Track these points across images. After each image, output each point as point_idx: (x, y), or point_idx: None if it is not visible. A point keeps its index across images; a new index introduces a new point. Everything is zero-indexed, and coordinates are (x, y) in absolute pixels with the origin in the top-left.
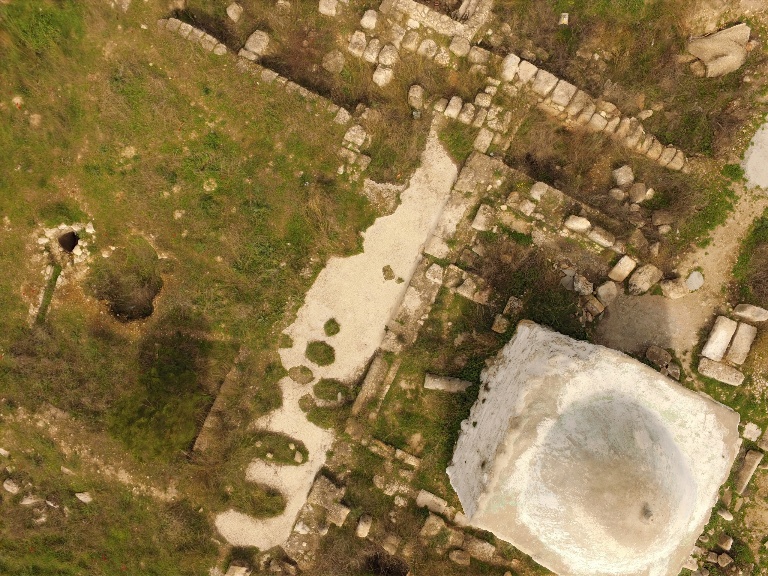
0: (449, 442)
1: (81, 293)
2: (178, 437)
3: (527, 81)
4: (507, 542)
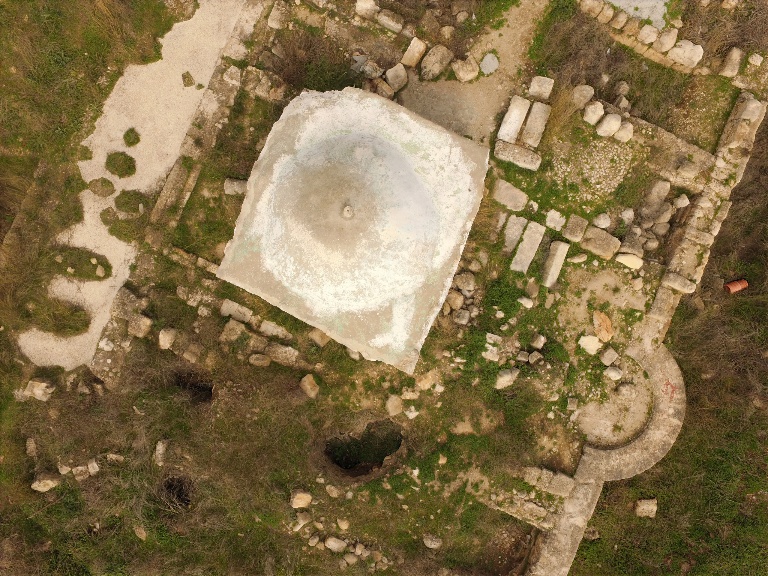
0: None
1: None
2: None
3: None
4: (310, 346)
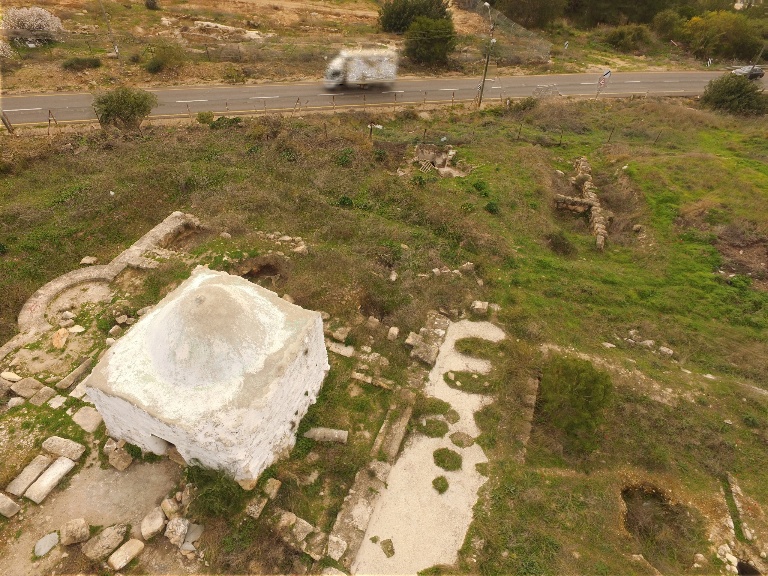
0: (327, 390)
1: (701, 510)
2: (552, 375)
3: None
4: None
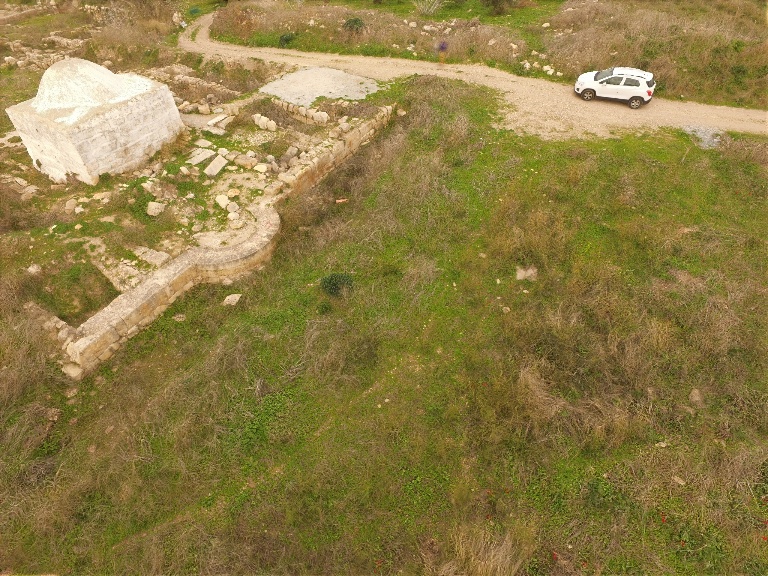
0: None
1: None
2: None
3: (184, 81)
4: None
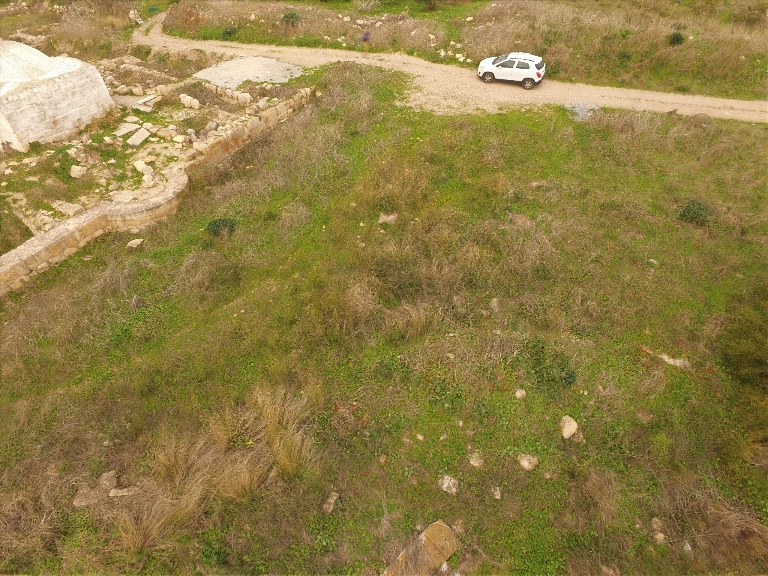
0: None
1: None
2: None
3: (129, 69)
4: None
